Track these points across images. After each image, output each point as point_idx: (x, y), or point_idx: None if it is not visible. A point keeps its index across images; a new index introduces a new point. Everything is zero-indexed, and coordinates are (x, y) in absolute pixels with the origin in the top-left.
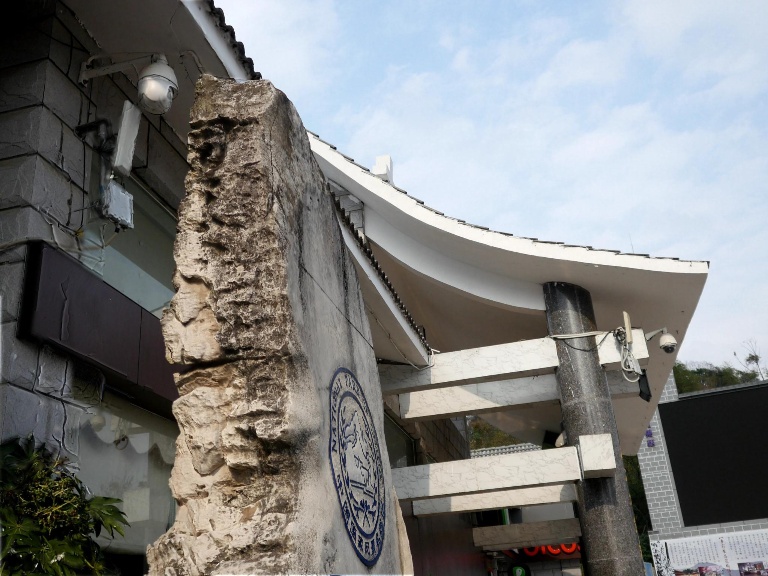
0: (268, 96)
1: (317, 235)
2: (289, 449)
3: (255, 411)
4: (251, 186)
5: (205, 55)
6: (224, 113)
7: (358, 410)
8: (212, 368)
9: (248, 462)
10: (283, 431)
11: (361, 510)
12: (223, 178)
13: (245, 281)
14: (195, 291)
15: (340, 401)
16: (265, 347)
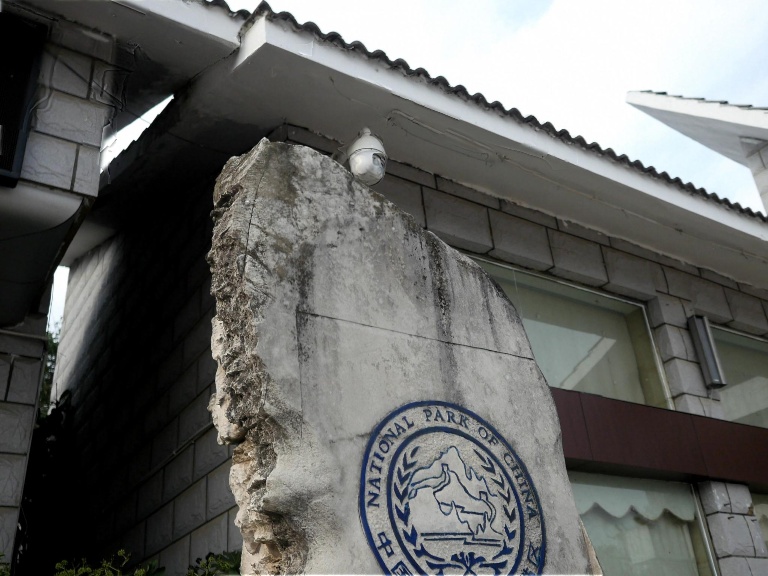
0: (252, 156)
1: (356, 268)
2: (284, 518)
3: (254, 482)
4: (230, 254)
5: (407, 107)
6: (224, 191)
7: (462, 444)
8: (241, 443)
9: (264, 536)
10: (264, 501)
11: (454, 566)
12: (214, 256)
13: (234, 351)
14: (222, 371)
15: (403, 443)
16: (252, 413)
